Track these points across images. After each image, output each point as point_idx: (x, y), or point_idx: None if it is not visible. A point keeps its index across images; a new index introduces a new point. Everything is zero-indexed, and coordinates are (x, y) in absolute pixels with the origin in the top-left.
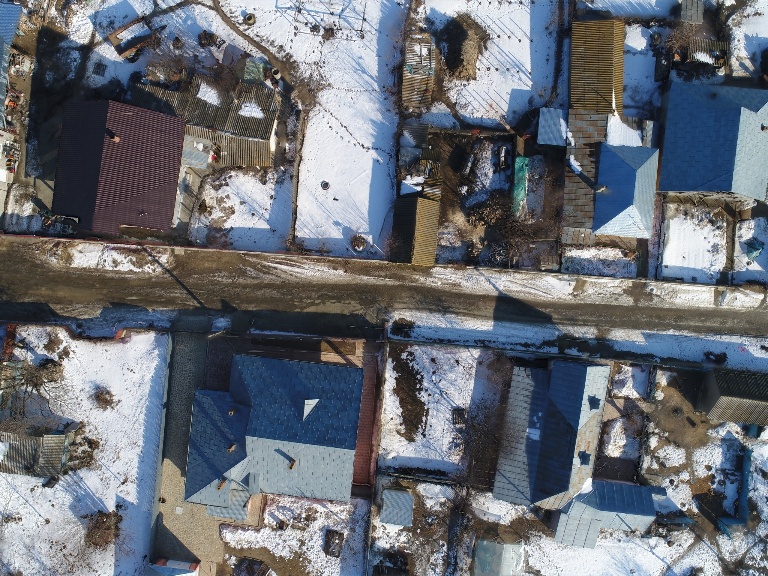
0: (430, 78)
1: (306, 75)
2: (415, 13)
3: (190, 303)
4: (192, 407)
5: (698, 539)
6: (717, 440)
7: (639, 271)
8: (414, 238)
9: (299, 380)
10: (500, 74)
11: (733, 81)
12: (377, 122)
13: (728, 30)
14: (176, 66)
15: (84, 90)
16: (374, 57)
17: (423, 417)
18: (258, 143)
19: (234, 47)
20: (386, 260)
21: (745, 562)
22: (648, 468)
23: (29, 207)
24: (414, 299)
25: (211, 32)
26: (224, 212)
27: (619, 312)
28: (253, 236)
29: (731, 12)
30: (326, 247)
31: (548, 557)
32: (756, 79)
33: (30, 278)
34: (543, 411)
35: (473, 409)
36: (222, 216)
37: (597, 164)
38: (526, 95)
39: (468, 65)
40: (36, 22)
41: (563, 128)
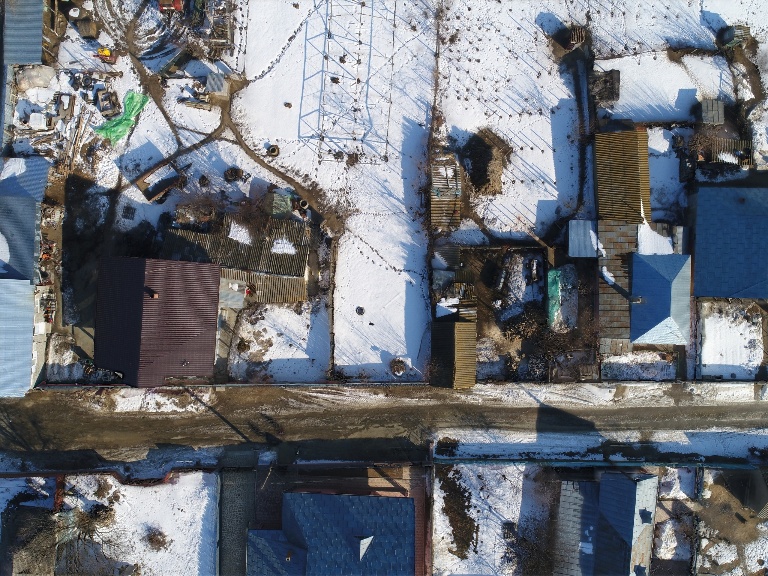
0: (457, 199)
1: (333, 202)
2: (437, 132)
3: (235, 438)
4: (246, 548)
5: None
6: (767, 534)
7: (678, 372)
8: (454, 363)
9: (351, 516)
10: (525, 186)
11: (758, 175)
12: (407, 244)
13: (749, 125)
14: (205, 207)
15: (115, 235)
16: (399, 179)
17: (474, 534)
18: (293, 280)
19: (260, 180)
20: (426, 382)
21: None
22: (701, 567)
23: (69, 356)
24: (456, 417)
25: (236, 167)
26: (262, 345)
27: (661, 414)
28: (292, 367)
29: (751, 106)
30: (366, 373)
31: None
32: None
33: (75, 426)
34: (594, 525)
35: (523, 522)
36: (260, 349)
37: (630, 274)
38: (553, 205)
39: (494, 183)
40: (63, 171)
41: (593, 240)
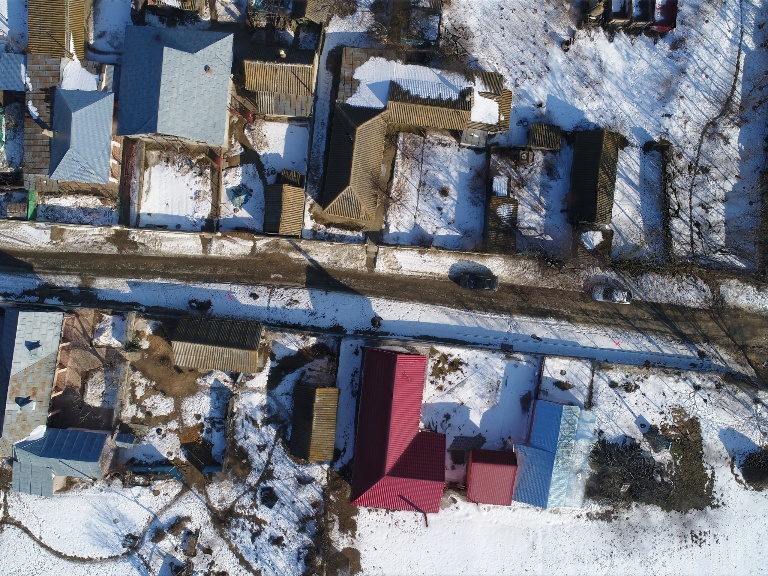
0: None
1: None
2: None
3: None
4: None
5: (186, 488)
6: (206, 389)
7: (121, 219)
8: None
9: None
10: None
11: (220, 26)
12: None
13: None
14: None
15: None
16: None
17: None
18: None
19: None
20: None
21: (235, 511)
22: (133, 417)
23: None
24: None
25: None
26: None
27: (103, 261)
28: None
29: None
30: None
31: (28, 508)
32: (242, 24)
33: None
34: None
35: None
36: None
37: (52, 109)
38: (2, 42)
39: None
40: None
41: (23, 73)
